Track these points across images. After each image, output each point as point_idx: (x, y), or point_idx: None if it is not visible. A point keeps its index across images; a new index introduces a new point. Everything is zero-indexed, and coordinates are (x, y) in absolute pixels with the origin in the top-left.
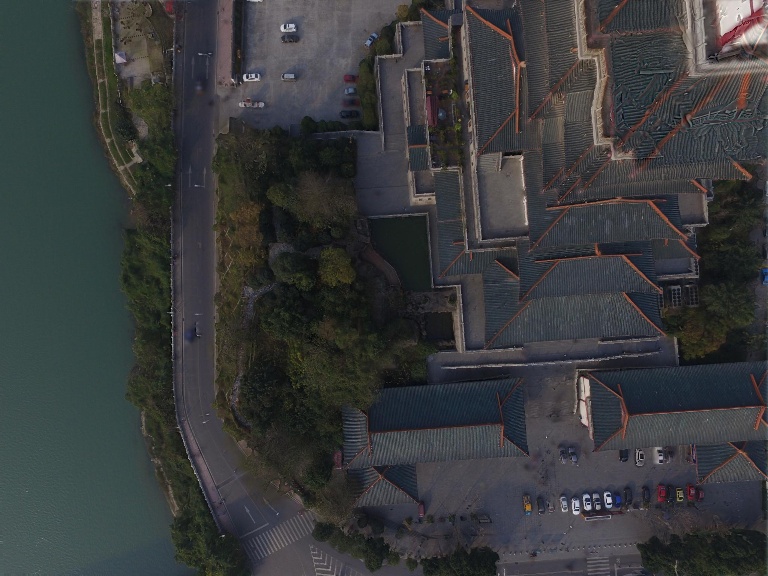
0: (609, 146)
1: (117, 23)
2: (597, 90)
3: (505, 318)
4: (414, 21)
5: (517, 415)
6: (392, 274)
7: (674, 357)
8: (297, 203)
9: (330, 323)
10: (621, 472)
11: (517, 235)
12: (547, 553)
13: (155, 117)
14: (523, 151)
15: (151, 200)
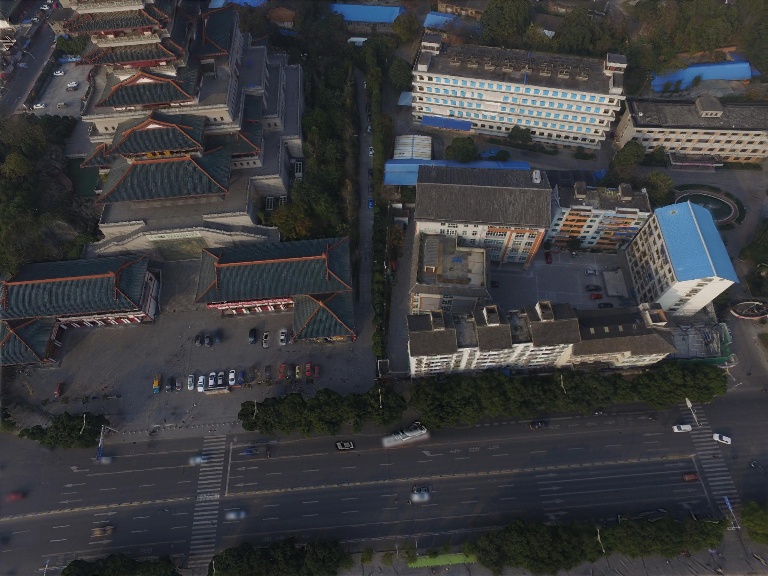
0: None
1: None
2: None
3: None
4: None
5: (138, 278)
6: (71, 187)
7: None
8: (5, 133)
9: None
10: (250, 354)
11: None
12: (166, 431)
13: None
14: None
15: None
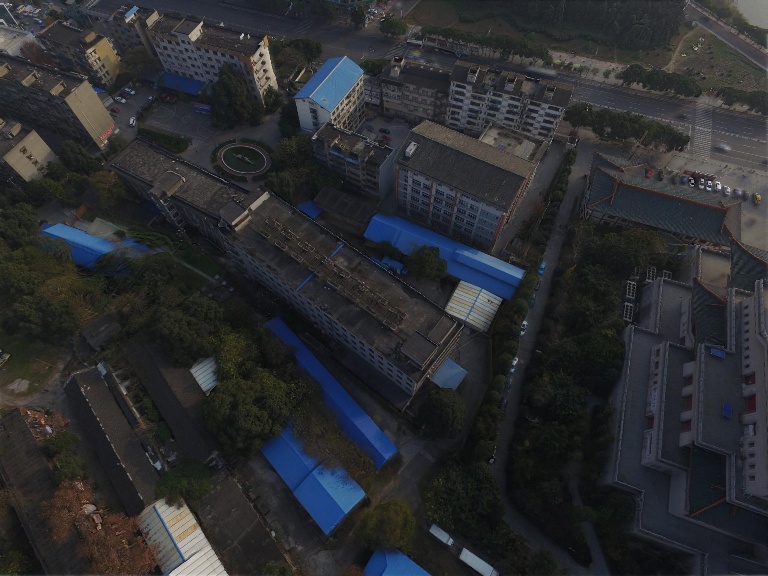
0: None
1: None
2: None
3: None
4: None
5: None
6: None
7: None
8: None
9: None
10: None
11: None
12: None
13: None
14: None
15: None
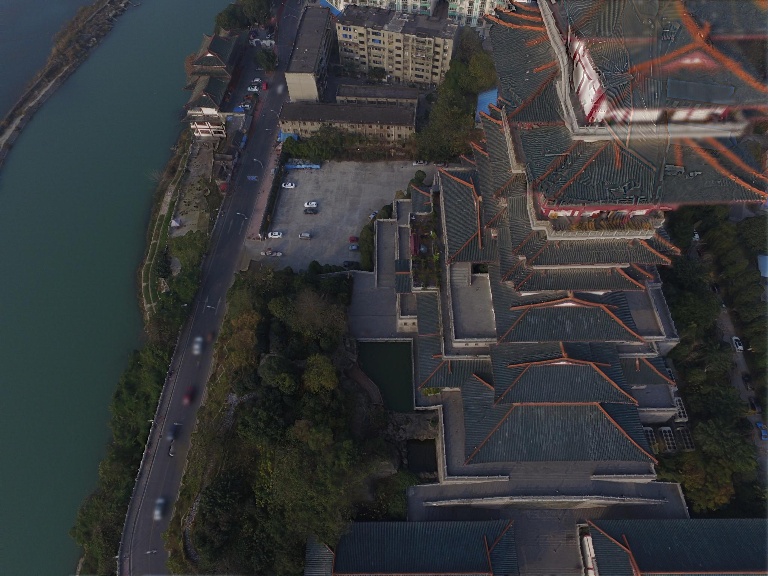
0: (544, 231)
1: (181, 202)
2: (528, 191)
3: (485, 432)
4: (407, 199)
5: (509, 568)
6: (375, 393)
7: (683, 510)
8: (293, 315)
9: (306, 421)
10: None
11: (488, 338)
12: None
13: (190, 257)
14: (488, 266)
15: (166, 318)
